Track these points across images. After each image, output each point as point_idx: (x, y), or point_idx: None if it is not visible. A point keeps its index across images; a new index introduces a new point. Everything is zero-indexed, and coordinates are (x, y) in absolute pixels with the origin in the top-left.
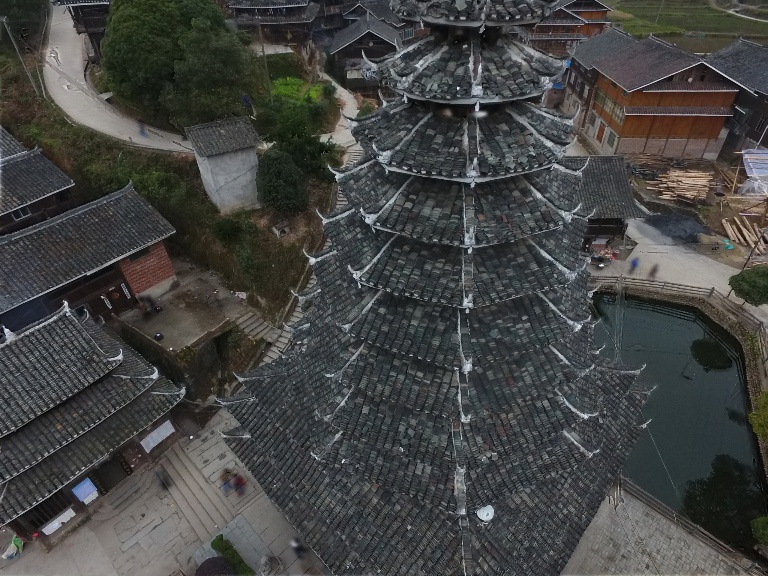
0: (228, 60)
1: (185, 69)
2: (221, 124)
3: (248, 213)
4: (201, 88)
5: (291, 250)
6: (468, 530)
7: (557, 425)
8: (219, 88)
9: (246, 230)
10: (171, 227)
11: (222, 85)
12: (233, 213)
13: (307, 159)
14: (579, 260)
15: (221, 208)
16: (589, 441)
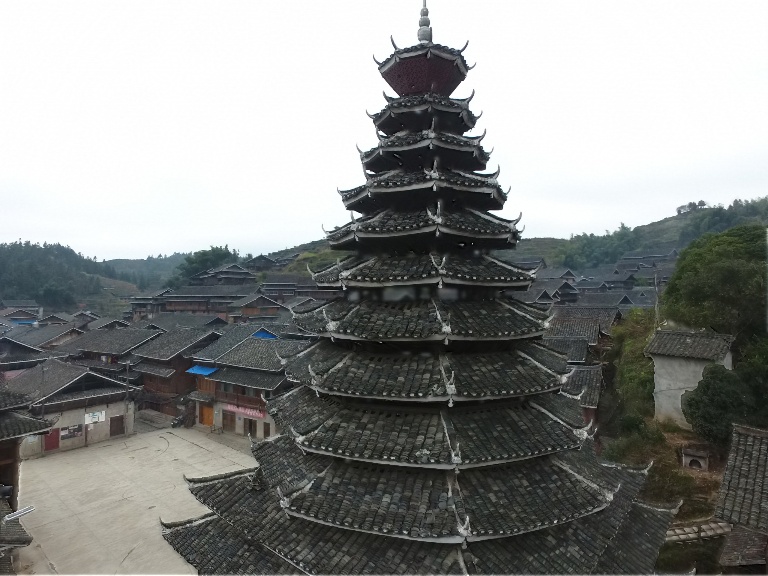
0: (731, 279)
1: (683, 284)
2: (695, 335)
3: (676, 428)
4: (690, 301)
5: (680, 481)
6: (247, 470)
7: None
8: (705, 302)
9: (643, 431)
10: (594, 402)
11: (710, 300)
12: (665, 424)
13: None
14: (437, 323)
15: (656, 413)
16: (302, 506)
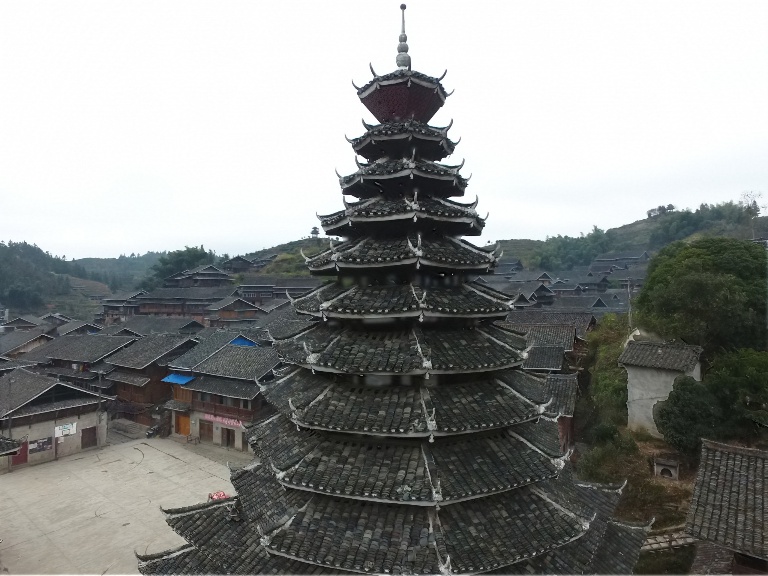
0: (700, 292)
1: (655, 296)
2: (666, 346)
3: (649, 437)
4: (661, 312)
5: (652, 490)
6: (226, 500)
7: (275, 465)
8: (676, 314)
9: (617, 441)
10: (570, 411)
11: (681, 312)
12: (638, 432)
13: (737, 403)
14: (418, 356)
15: (629, 422)
16: (283, 545)
